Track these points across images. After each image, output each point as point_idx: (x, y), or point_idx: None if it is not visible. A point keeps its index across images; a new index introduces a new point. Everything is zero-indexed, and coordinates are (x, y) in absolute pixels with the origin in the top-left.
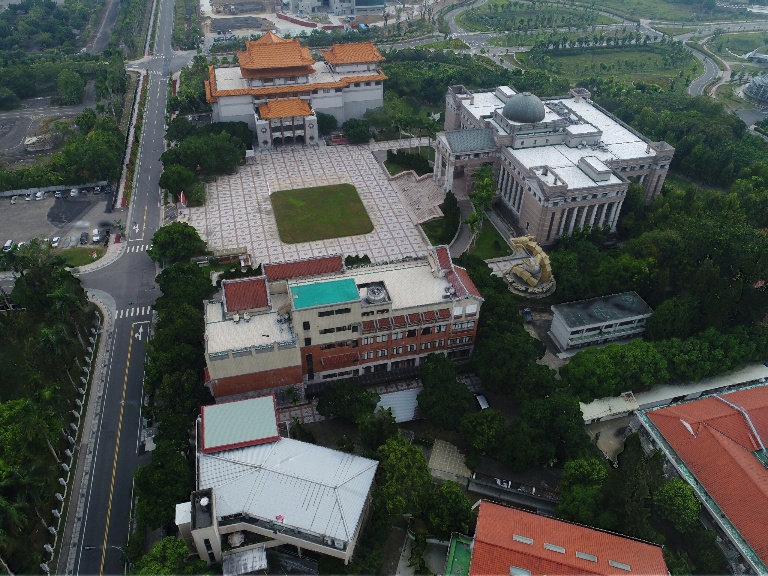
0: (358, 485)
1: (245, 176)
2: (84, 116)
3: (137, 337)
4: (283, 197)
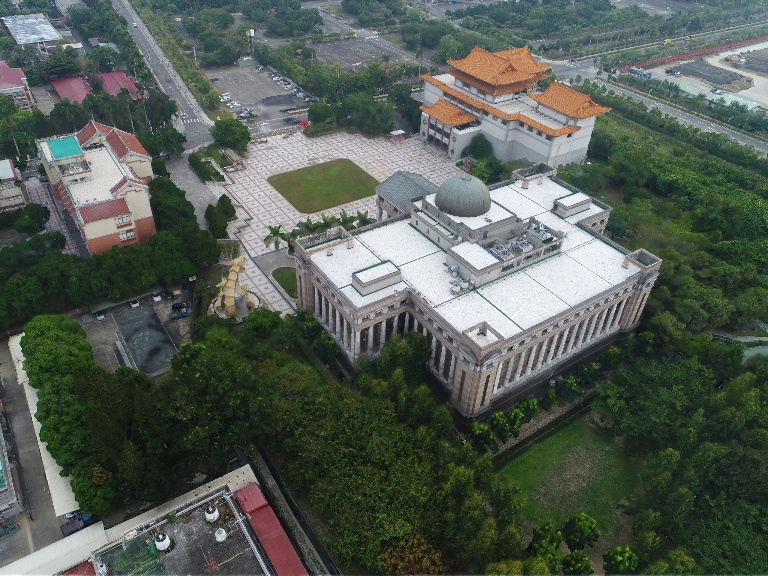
0: None
1: (367, 142)
2: (403, 66)
3: None
4: (340, 164)
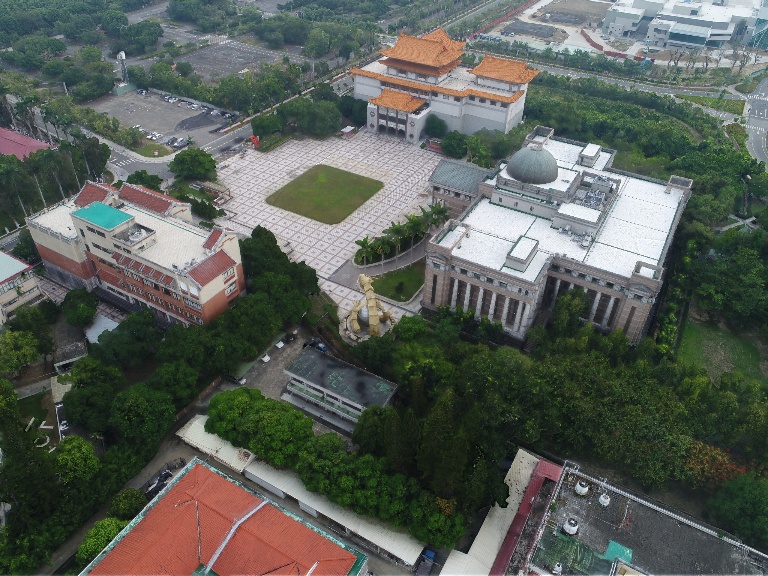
0: None
1: (324, 145)
2: (292, 65)
3: None
4: (320, 170)
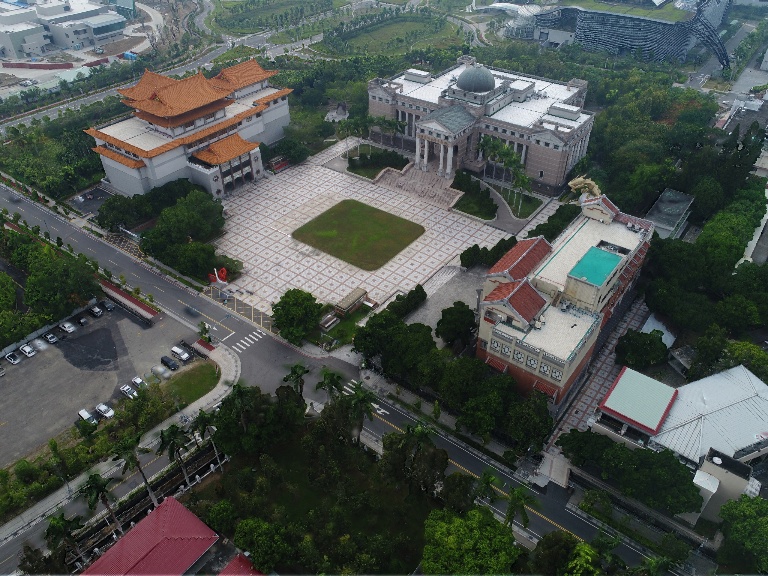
0: (759, 385)
1: (240, 231)
2: None
3: (383, 413)
4: (308, 234)
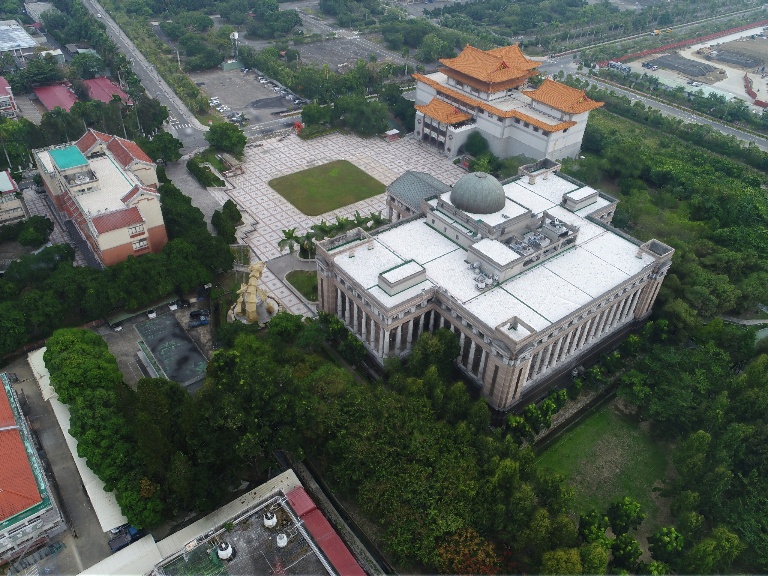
0: None
1: (362, 143)
2: (389, 65)
3: None
4: (339, 165)
